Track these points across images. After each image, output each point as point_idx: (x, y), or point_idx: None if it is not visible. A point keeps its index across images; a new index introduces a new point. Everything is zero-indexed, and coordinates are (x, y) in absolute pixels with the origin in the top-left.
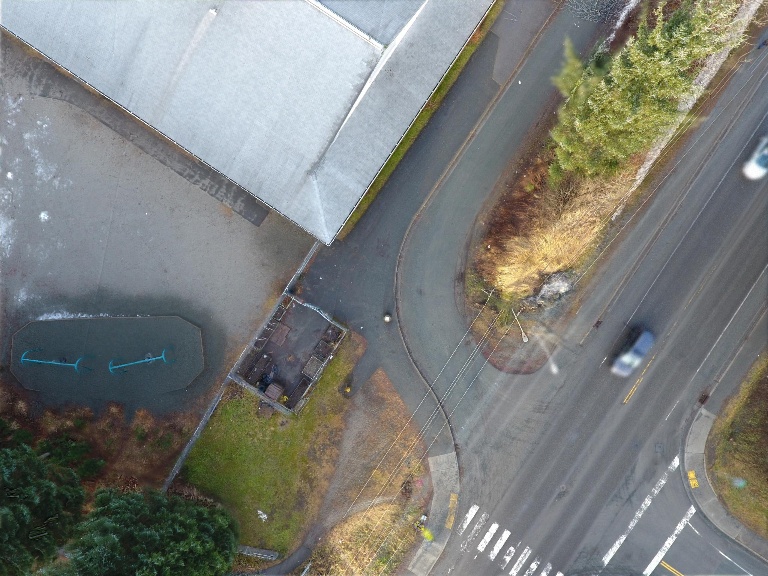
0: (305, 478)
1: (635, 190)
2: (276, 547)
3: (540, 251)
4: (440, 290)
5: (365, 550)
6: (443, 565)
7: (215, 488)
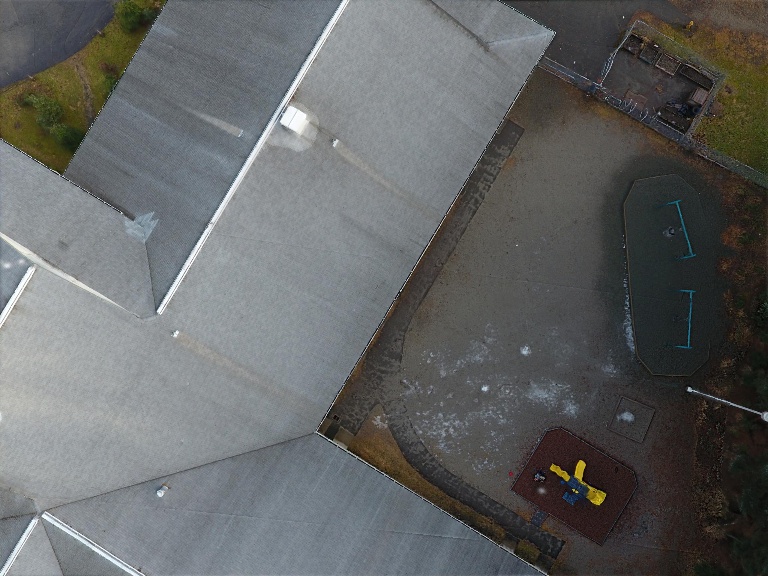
0: None
1: None
2: None
3: None
4: None
5: None
6: None
7: None
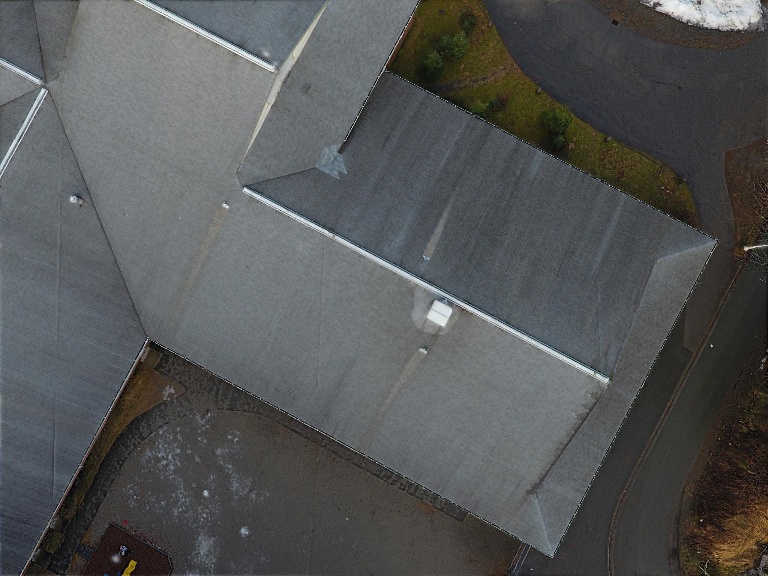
0: None
1: None
2: None
3: (760, 527)
4: (655, 569)
5: None
6: None
7: None
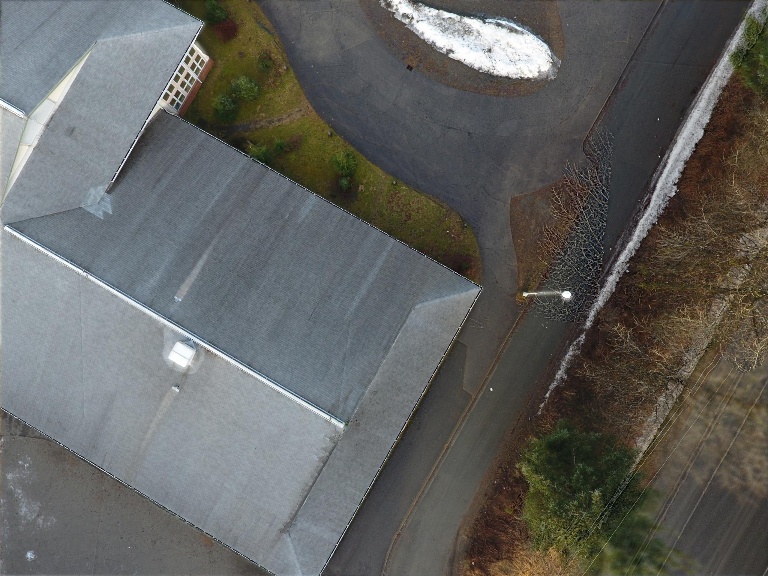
0: None
1: (620, 495)
2: None
3: (525, 573)
4: None
5: None
6: None
7: None
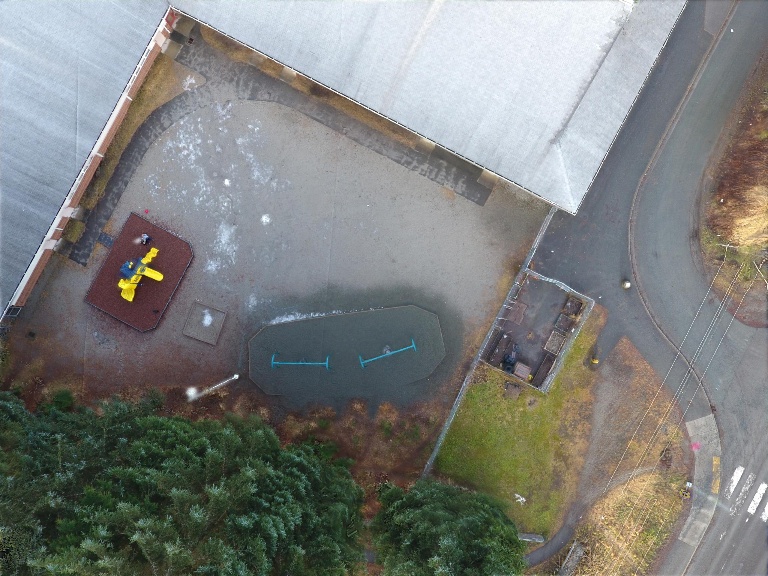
0: (559, 456)
1: None
2: (537, 530)
3: None
4: (676, 250)
5: (630, 524)
6: (714, 531)
7: (468, 476)
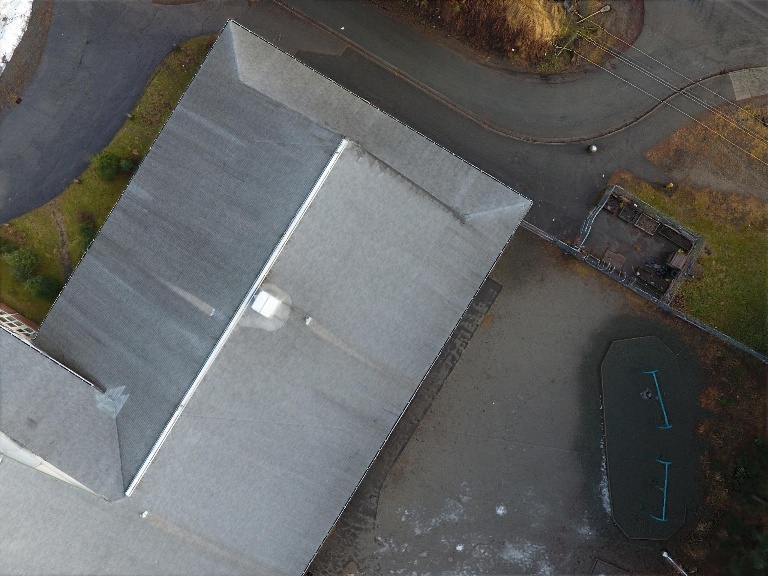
0: (763, 227)
1: None
2: None
3: None
4: (560, 98)
5: None
6: None
7: None
